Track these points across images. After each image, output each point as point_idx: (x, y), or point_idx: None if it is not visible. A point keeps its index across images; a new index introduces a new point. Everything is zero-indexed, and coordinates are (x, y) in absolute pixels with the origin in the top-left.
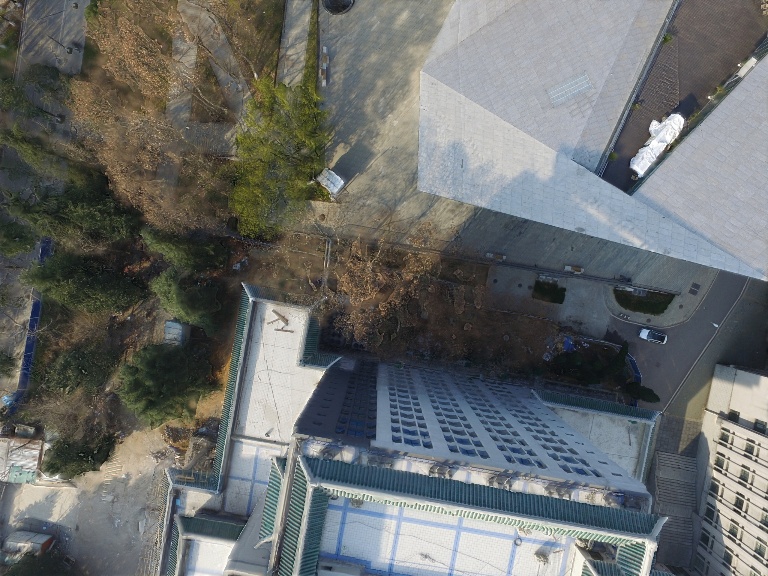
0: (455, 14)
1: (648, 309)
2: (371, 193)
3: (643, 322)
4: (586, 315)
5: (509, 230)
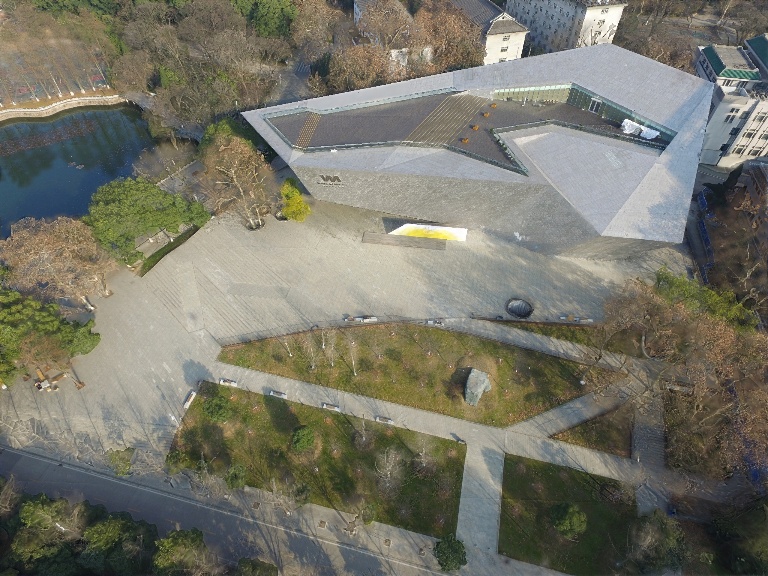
0: None
1: None
2: None
3: None
4: None
5: None
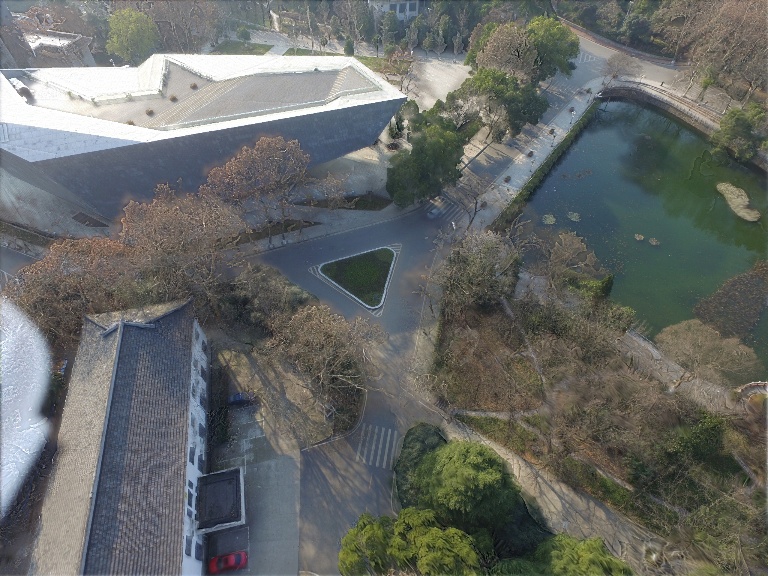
0: None
1: None
2: None
3: None
4: None
5: None
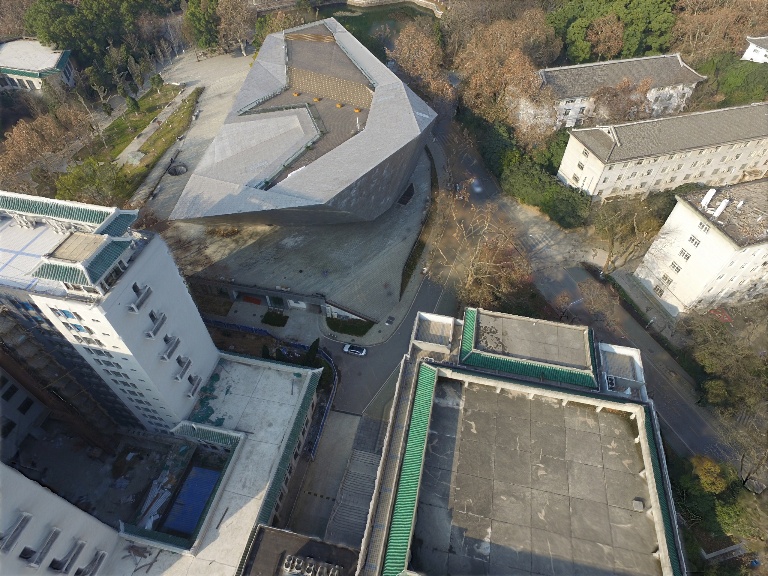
0: (212, 149)
1: (352, 331)
2: None
3: (348, 341)
4: (302, 335)
5: (242, 267)
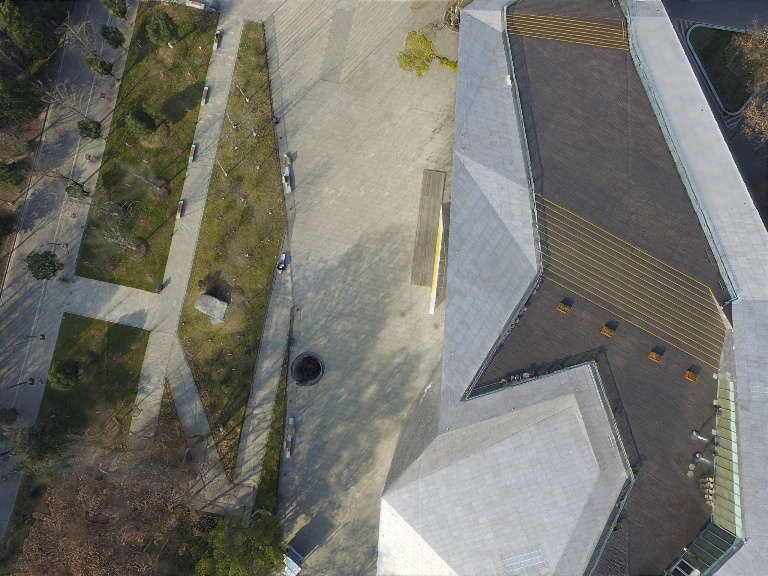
0: (416, 465)
1: None
2: (330, 566)
3: None
4: None
5: None
